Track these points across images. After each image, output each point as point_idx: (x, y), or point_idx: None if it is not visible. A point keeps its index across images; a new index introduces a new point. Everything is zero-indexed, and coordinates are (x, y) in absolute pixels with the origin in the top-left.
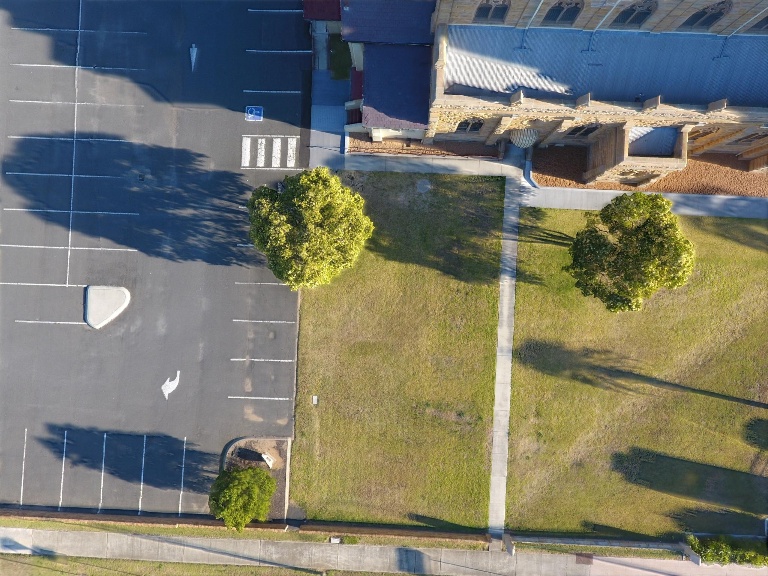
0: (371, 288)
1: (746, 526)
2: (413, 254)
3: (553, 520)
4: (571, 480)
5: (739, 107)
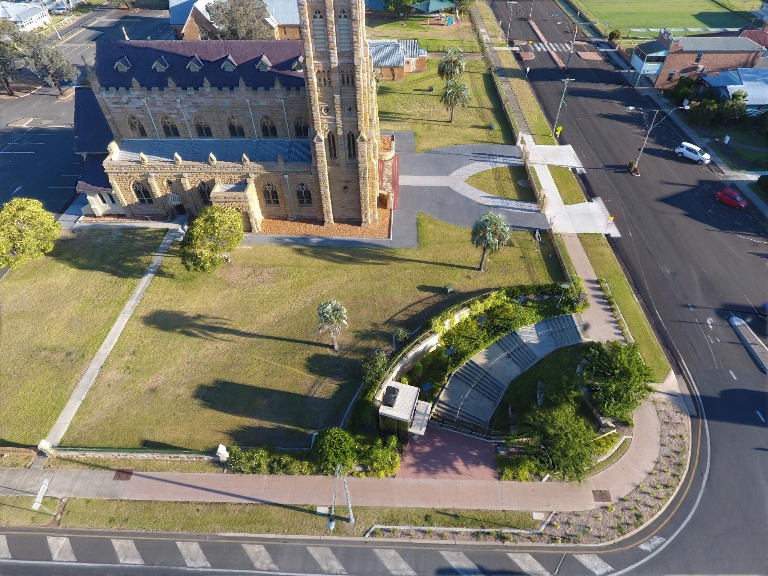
0: (49, 282)
1: (293, 439)
2: (91, 265)
3: (108, 437)
4: (140, 402)
5: (260, 161)
